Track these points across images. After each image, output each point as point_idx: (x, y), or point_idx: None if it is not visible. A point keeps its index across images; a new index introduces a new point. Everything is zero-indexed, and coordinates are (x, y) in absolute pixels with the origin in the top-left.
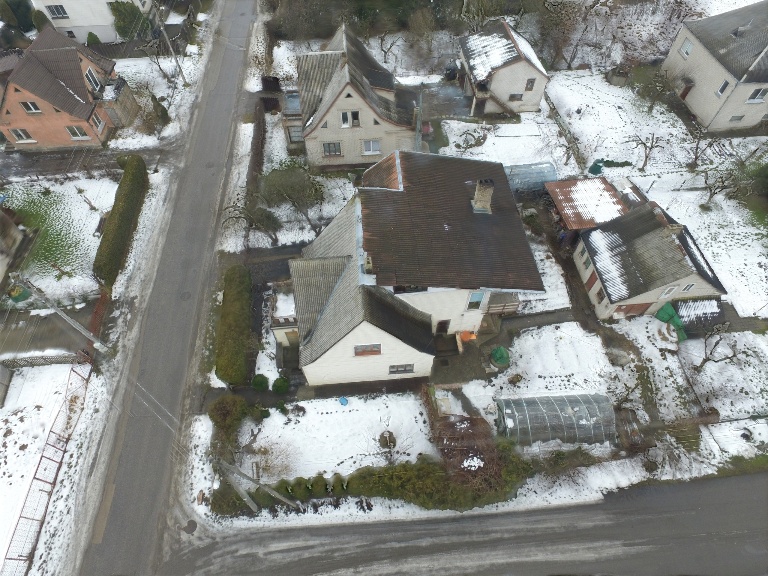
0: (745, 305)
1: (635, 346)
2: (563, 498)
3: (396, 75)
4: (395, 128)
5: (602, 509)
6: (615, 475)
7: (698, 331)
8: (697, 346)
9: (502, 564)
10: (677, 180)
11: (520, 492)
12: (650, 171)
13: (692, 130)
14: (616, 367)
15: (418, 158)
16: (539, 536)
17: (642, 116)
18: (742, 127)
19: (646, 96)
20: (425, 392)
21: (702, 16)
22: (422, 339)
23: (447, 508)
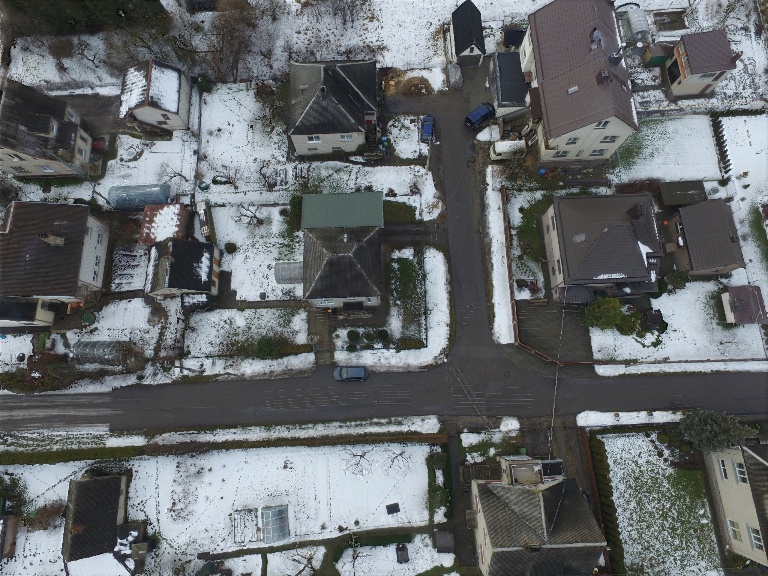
0: (242, 293)
1: (167, 314)
2: (93, 389)
3: (96, 85)
4: (51, 161)
5: (109, 395)
6: (120, 381)
7: (203, 308)
8: (201, 316)
9: (55, 415)
10: (256, 197)
11: (74, 386)
12: (242, 189)
13: (290, 153)
14: (150, 326)
15: (26, 207)
16: (76, 405)
17: (263, 136)
18: (323, 153)
19: (277, 116)
20: (32, 338)
21: (374, 20)
22: (23, 314)
23: (19, 393)
